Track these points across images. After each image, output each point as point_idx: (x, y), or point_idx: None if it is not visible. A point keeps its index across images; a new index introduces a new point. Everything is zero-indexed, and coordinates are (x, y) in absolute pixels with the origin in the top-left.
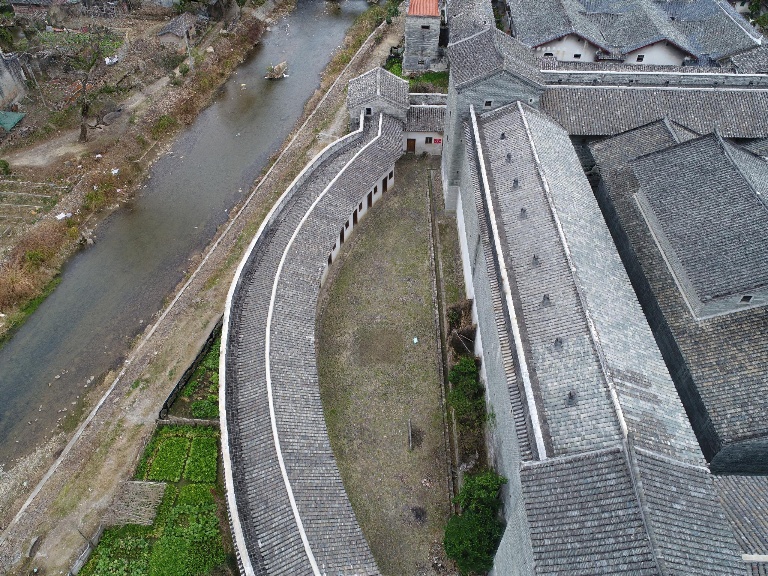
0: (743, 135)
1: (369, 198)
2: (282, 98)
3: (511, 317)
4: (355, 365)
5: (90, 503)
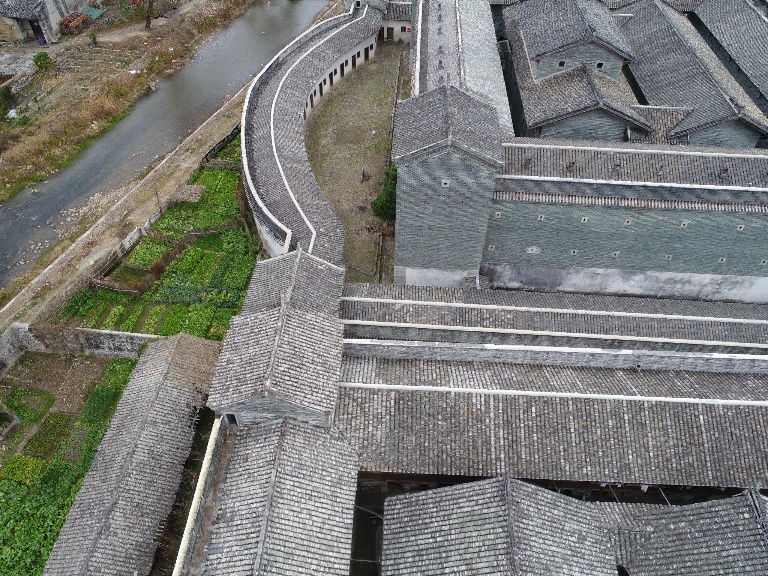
0: (615, 7)
1: (354, 60)
2: (299, 12)
3: (416, 69)
4: (332, 144)
5: (159, 198)
